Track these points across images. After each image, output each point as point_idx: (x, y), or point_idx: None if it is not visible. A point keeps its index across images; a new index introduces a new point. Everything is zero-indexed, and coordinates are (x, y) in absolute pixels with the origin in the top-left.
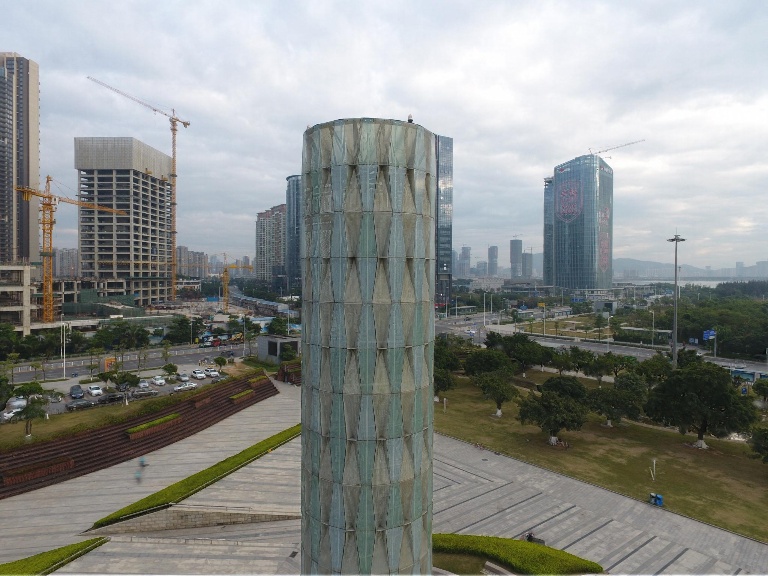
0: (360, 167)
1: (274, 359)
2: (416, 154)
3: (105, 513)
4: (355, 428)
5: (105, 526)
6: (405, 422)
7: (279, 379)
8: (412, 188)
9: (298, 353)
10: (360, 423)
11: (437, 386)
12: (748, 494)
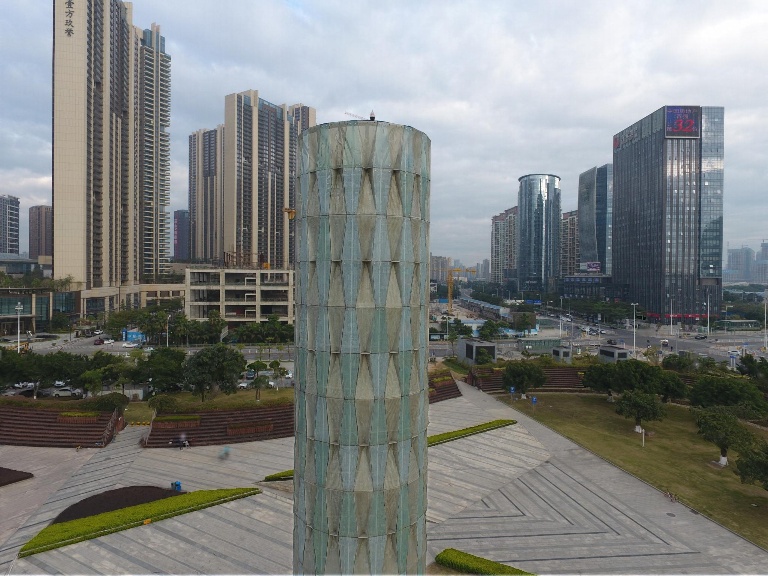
0: (318, 173)
1: (470, 362)
2: (379, 152)
3: (277, 471)
4: (314, 428)
5: (270, 481)
6: (363, 431)
7: (468, 382)
8: (372, 188)
9: (495, 358)
10: (316, 423)
11: (637, 413)
12: None
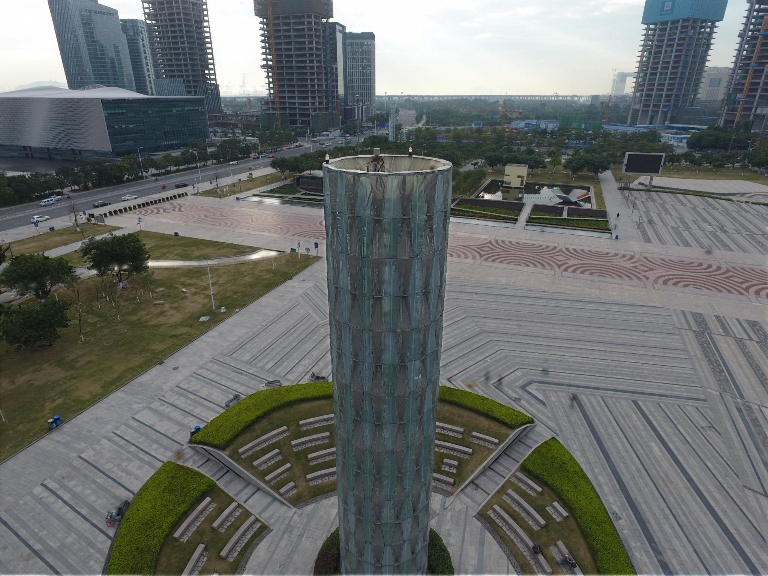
0: None
1: None
2: None
3: None
4: None
5: None
6: None
7: None
8: None
9: None
10: None
11: None
12: (53, 374)
